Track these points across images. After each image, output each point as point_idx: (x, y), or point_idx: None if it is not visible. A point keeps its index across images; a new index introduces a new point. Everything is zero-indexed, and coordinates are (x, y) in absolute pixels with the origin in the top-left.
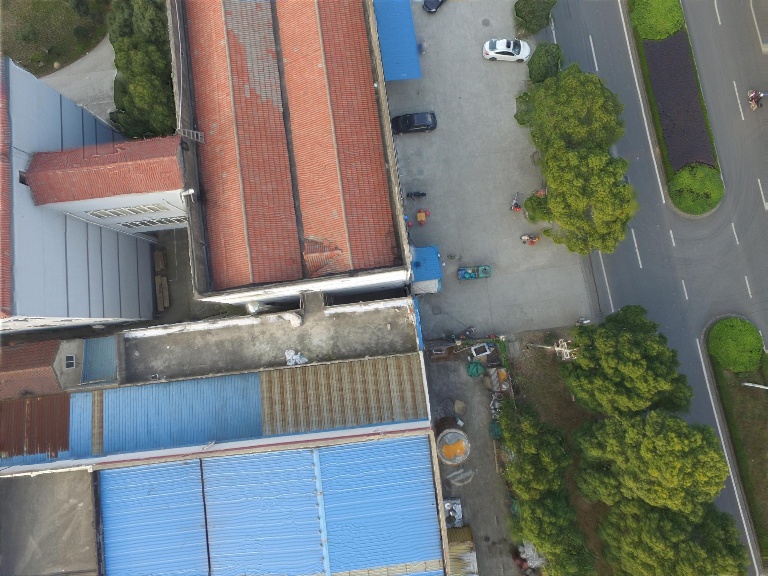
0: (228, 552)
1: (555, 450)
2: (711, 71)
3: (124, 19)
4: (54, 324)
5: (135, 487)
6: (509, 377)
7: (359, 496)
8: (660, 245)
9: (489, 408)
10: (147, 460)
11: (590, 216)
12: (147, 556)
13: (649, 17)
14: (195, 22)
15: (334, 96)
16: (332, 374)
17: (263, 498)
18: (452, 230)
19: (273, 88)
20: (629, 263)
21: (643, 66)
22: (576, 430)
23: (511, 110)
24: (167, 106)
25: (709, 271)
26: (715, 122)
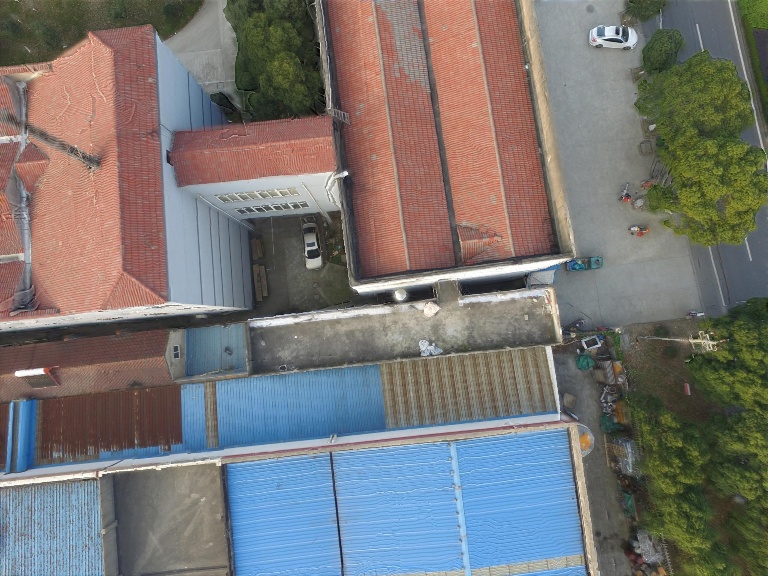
0: (362, 548)
1: (700, 443)
2: None
3: None
4: (168, 313)
5: (264, 481)
6: (624, 370)
7: (497, 490)
8: None
9: (599, 401)
10: (278, 453)
11: (724, 206)
12: (277, 552)
13: (760, 6)
14: None
15: (490, 77)
16: (455, 366)
17: (398, 492)
18: None
19: (420, 68)
20: (739, 255)
21: (753, 56)
22: (708, 424)
23: (617, 99)
24: None
25: None
26: None
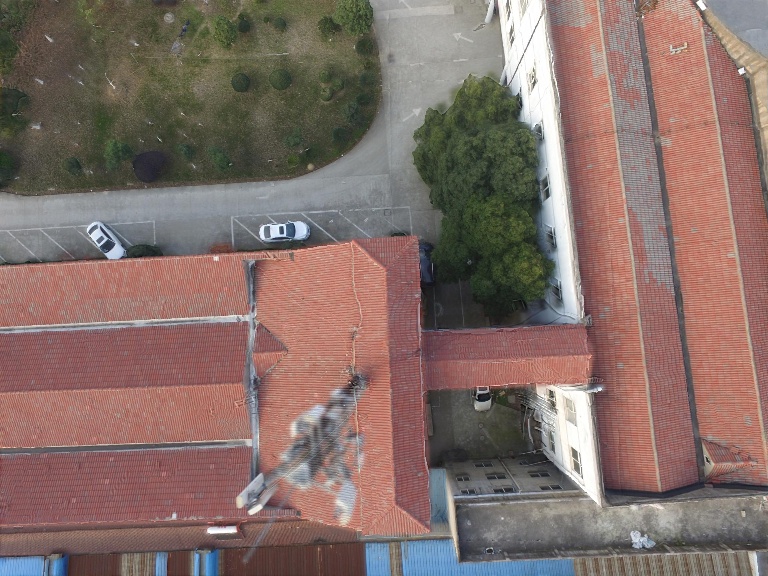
0: None
1: None
2: None
3: (481, 172)
4: None
5: None
6: None
7: None
8: None
9: None
10: None
11: None
12: None
13: None
14: (579, 191)
15: (747, 291)
16: None
17: None
18: None
19: (666, 270)
20: None
21: None
22: None
23: None
24: None
25: None
26: None
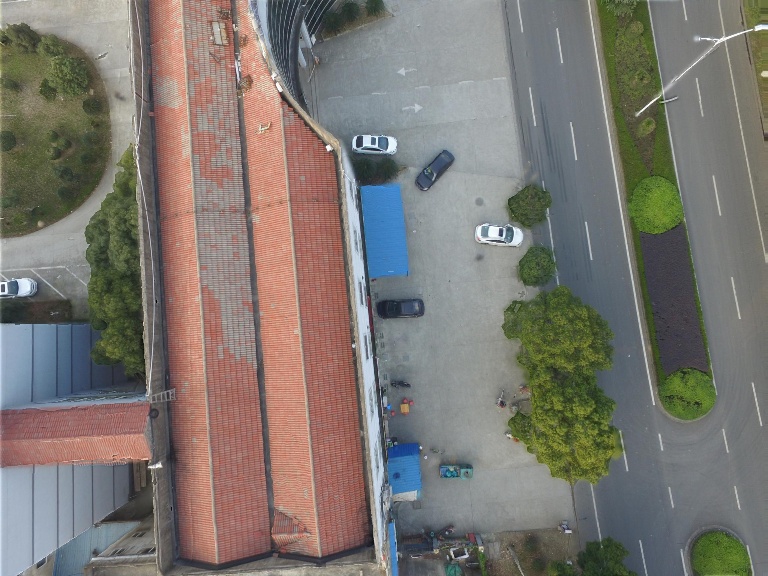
0: None
1: None
2: (709, 267)
3: (100, 247)
4: None
5: None
6: None
7: None
8: (648, 448)
9: None
10: None
11: None
12: None
13: (647, 211)
14: (170, 268)
15: (309, 366)
16: None
17: None
18: (436, 421)
19: (248, 344)
20: (615, 465)
21: (639, 260)
22: None
23: (501, 297)
24: (140, 351)
25: (697, 479)
26: (710, 323)
